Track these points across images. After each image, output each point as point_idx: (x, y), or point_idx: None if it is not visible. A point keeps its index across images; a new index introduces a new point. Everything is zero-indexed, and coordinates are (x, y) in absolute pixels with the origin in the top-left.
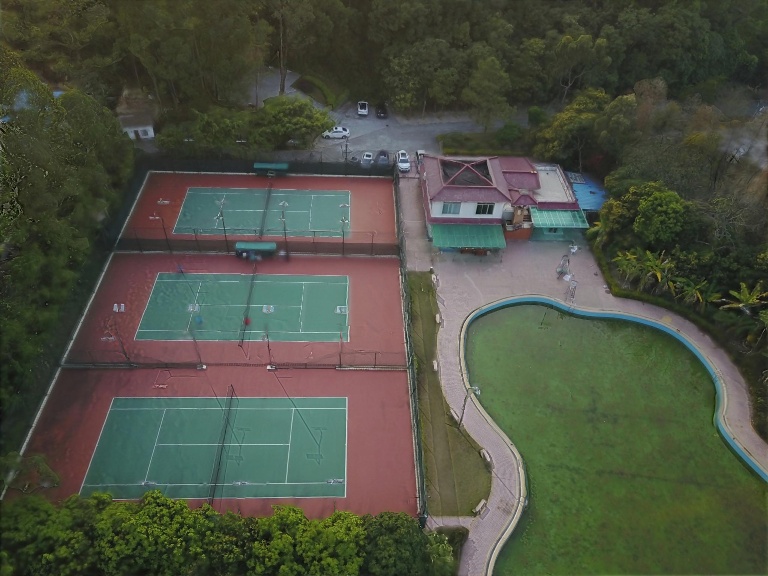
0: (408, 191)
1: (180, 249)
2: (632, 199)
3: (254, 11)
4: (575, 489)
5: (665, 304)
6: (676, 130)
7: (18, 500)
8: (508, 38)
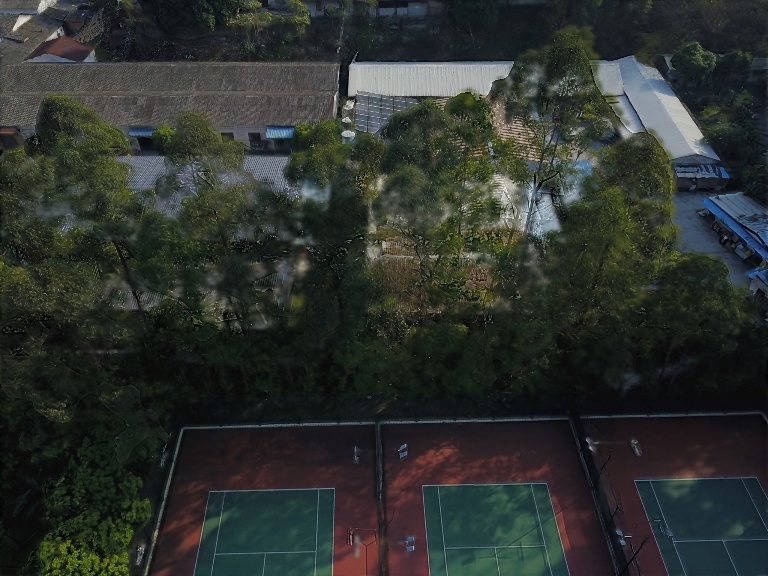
0: None
1: None
2: None
3: None
4: None
5: None
6: None
7: None
8: None
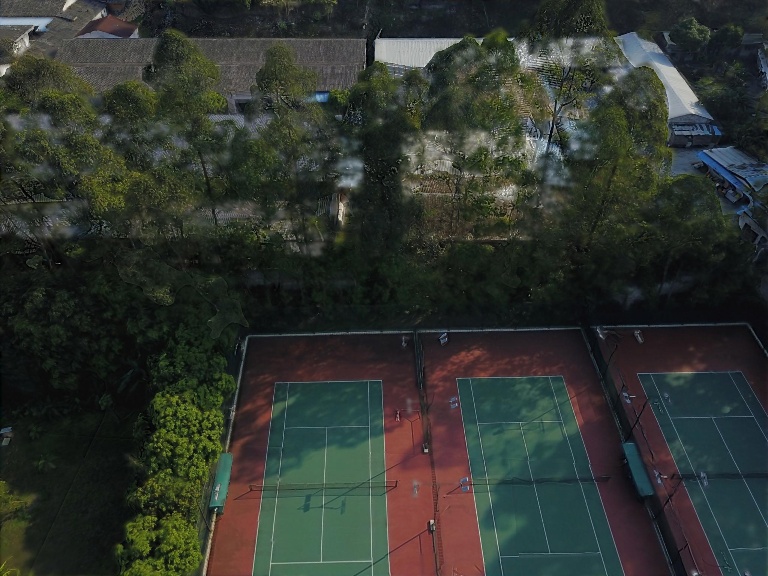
0: None
1: None
2: None
3: None
4: None
5: None
6: None
7: None
8: None
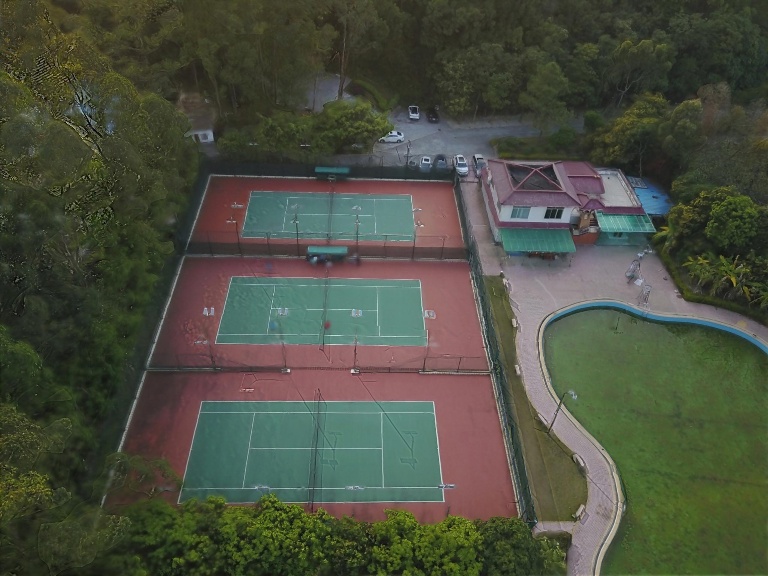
0: (469, 195)
1: (251, 253)
2: (703, 204)
3: (320, 16)
4: (670, 494)
5: (739, 309)
6: (740, 135)
7: (141, 504)
8: (563, 43)
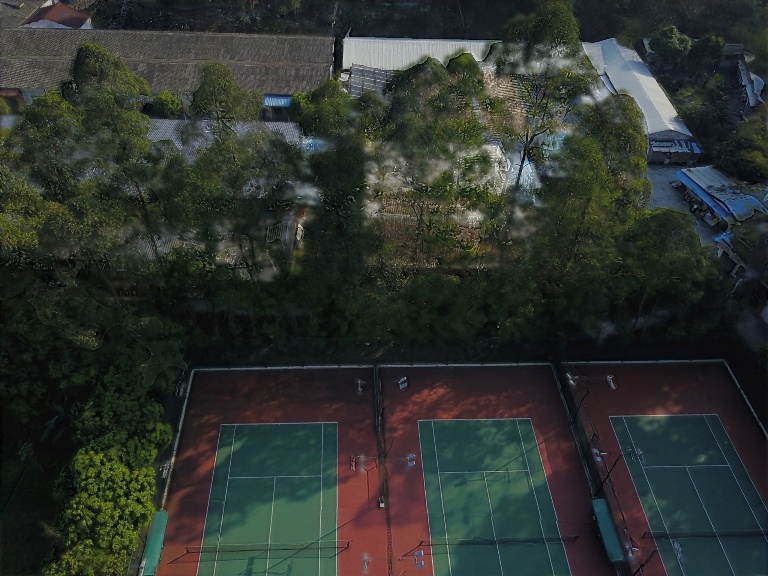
0: None
1: None
2: None
3: None
4: None
5: None
6: None
7: None
8: None
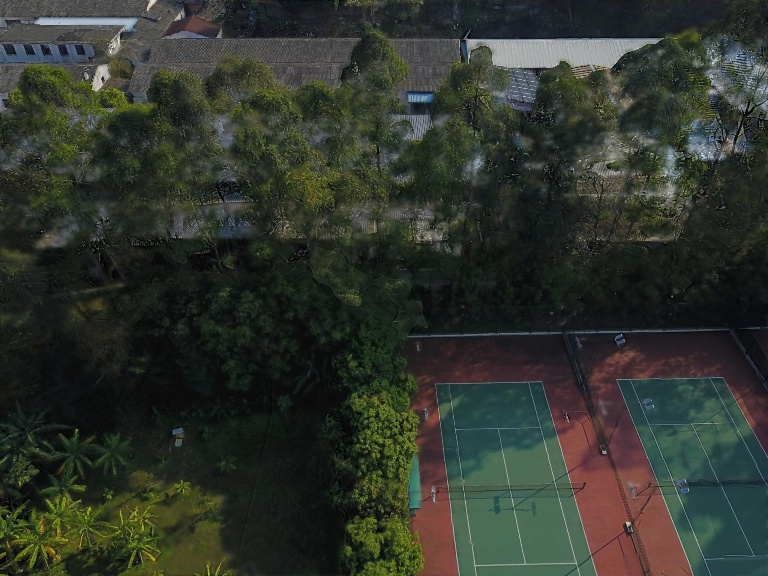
0: None
1: None
2: None
3: None
4: None
5: None
6: None
7: None
8: None
